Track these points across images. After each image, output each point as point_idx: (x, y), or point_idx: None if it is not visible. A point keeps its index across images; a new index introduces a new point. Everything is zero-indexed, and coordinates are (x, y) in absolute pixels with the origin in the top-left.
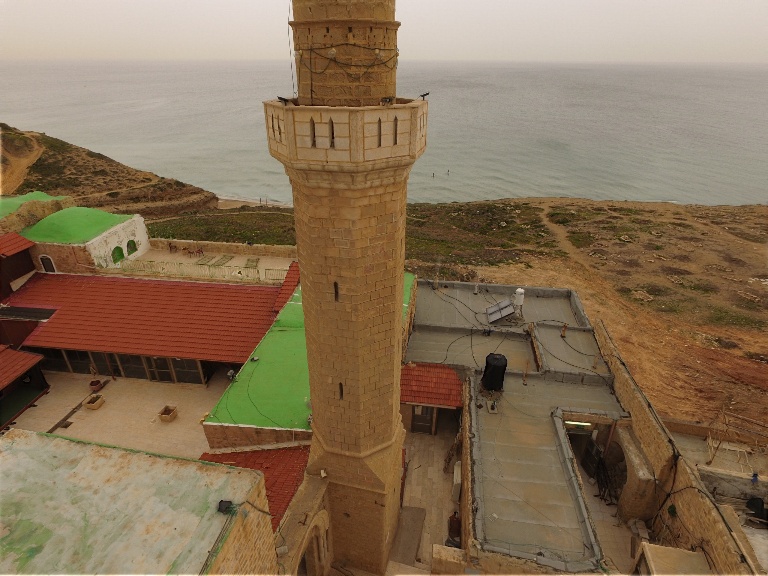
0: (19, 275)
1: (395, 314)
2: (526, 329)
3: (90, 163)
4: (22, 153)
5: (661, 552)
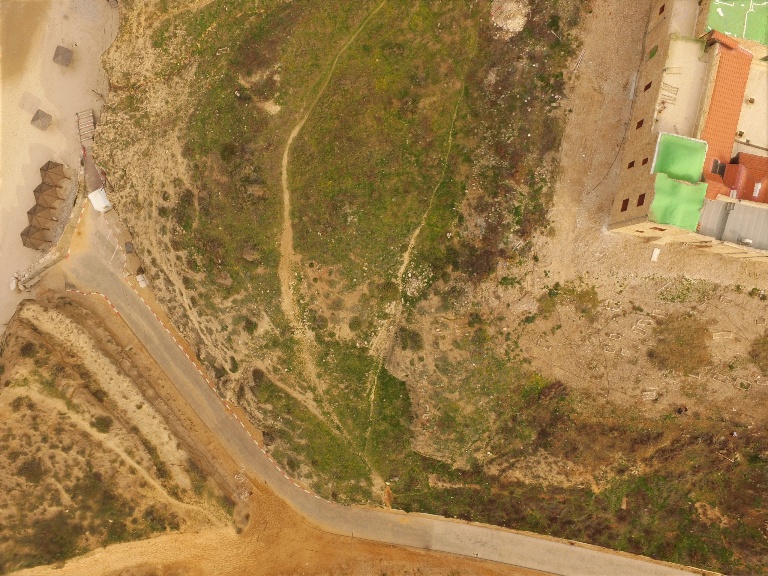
0: None
1: None
2: None
3: (0, 500)
4: None
5: None
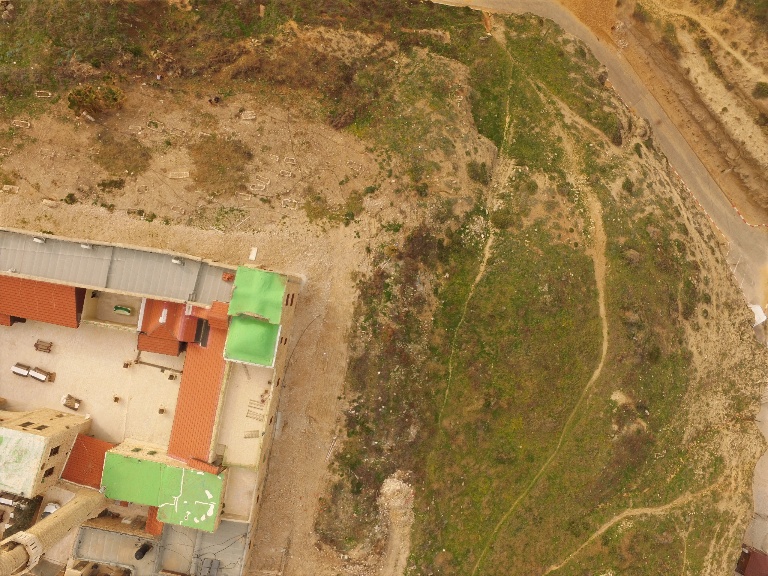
0: None
1: None
2: (192, 575)
3: None
4: None
5: (77, 575)
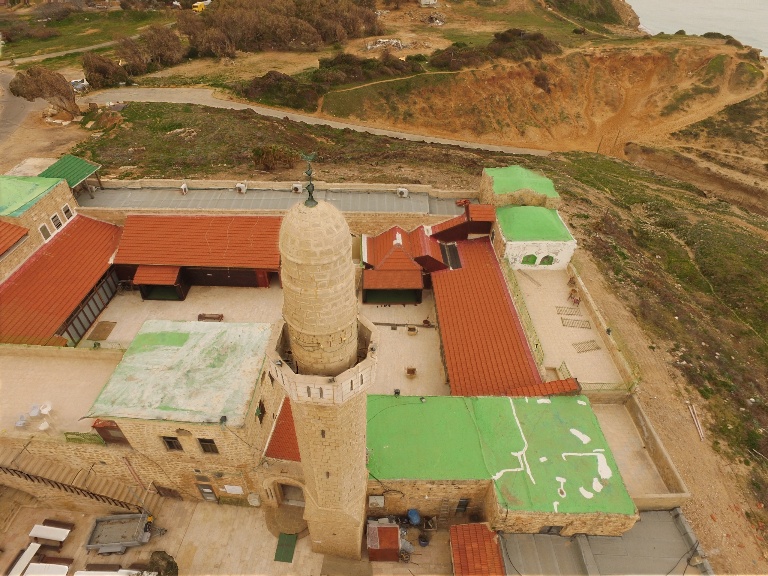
0: (477, 232)
1: (311, 455)
2: None
3: None
4: (738, 89)
5: None
